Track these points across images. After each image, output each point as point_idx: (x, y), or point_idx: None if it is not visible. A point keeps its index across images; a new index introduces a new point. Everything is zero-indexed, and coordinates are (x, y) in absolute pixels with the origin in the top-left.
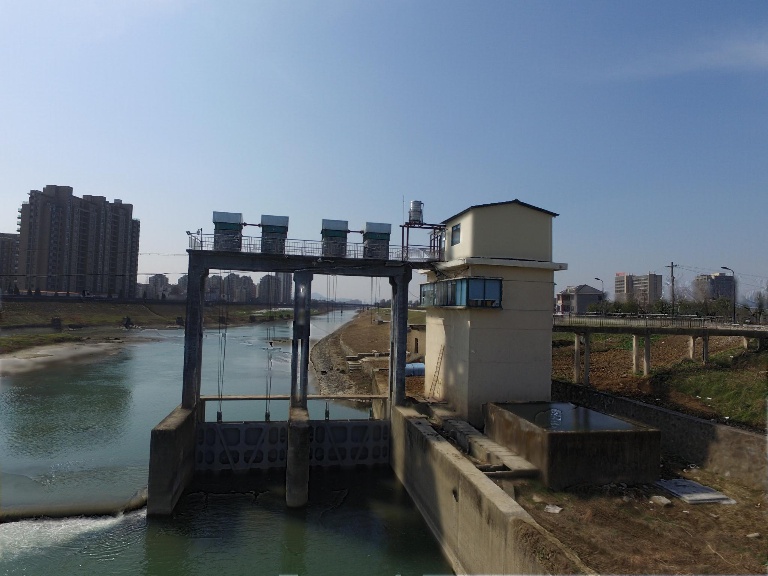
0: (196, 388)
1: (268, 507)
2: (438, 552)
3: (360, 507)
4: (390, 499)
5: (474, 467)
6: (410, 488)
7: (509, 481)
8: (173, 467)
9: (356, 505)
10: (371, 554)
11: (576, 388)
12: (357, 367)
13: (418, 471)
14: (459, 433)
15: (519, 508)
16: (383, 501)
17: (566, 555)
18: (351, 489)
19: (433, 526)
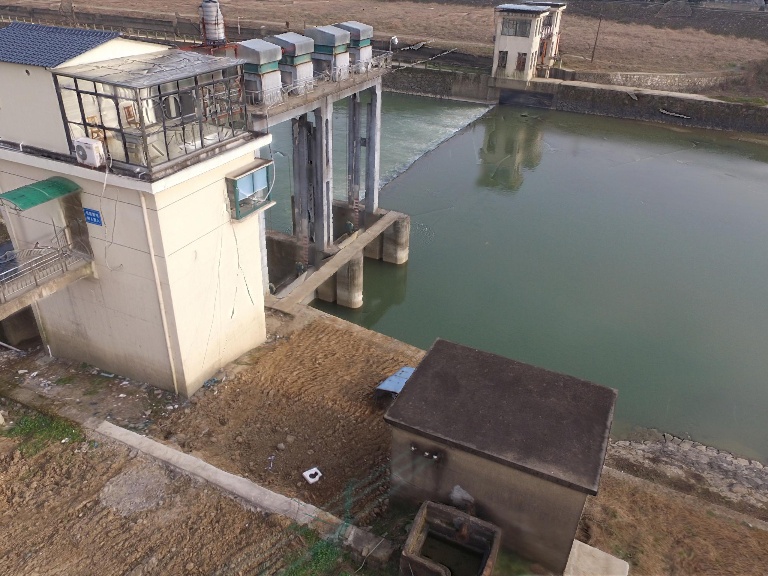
0: (357, 195)
1: None
2: None
3: None
4: None
5: None
6: None
7: None
8: (294, 220)
9: None
10: None
11: (1, 378)
12: None
13: None
14: None
15: None
16: None
17: None
18: None
19: None
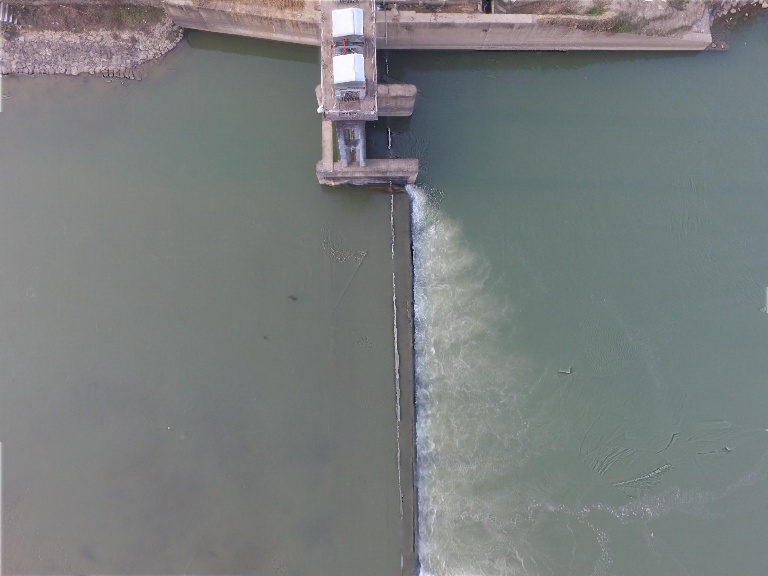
0: None
1: (406, 127)
2: (460, 52)
3: (425, 78)
4: (407, 61)
5: (487, 15)
6: (409, 46)
7: (496, 5)
8: None
9: (422, 80)
10: (457, 81)
11: None
12: (3, 9)
13: (426, 37)
14: (429, 0)
15: (529, 15)
16: (411, 65)
17: (563, 18)
18: (403, 79)
19: (450, 47)
